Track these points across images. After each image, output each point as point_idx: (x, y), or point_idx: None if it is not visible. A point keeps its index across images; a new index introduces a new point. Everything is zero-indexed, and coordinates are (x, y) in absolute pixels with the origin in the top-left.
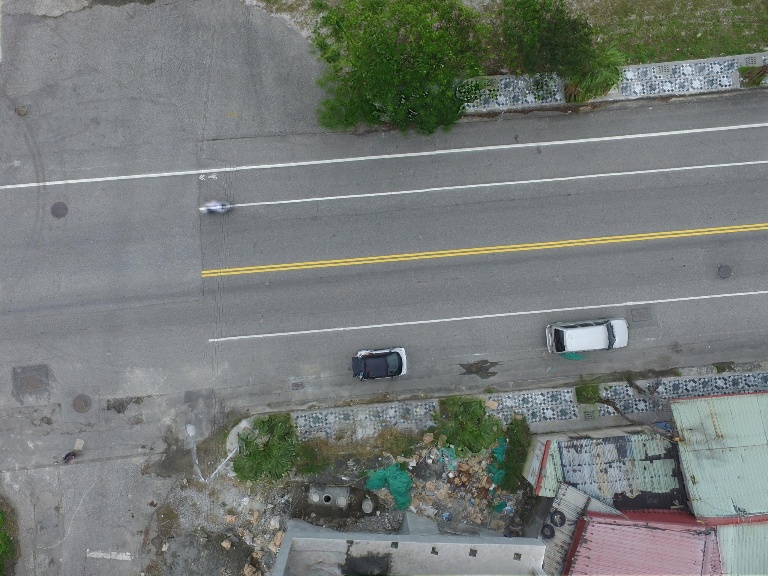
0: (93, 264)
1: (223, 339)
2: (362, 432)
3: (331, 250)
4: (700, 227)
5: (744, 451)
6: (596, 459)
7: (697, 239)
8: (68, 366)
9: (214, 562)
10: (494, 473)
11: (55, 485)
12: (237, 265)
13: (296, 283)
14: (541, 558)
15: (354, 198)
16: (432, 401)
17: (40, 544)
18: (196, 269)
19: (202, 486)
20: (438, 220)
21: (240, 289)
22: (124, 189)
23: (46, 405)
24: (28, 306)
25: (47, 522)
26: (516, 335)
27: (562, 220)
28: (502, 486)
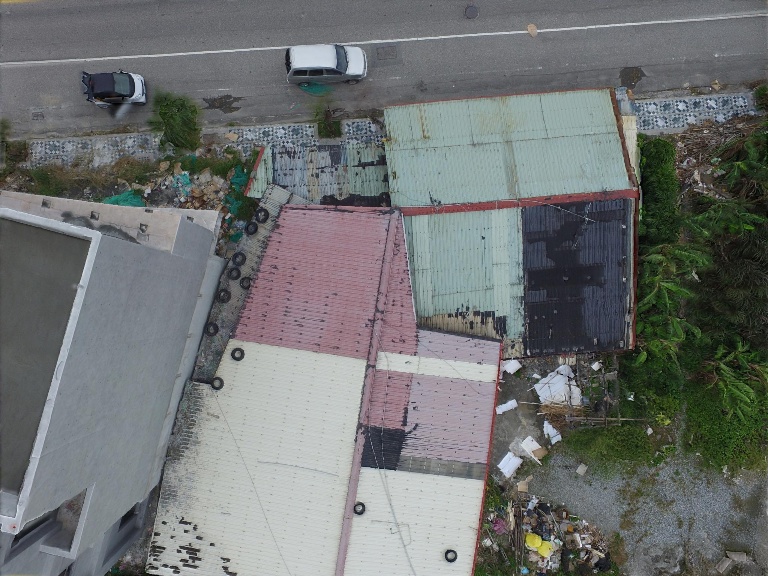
0: None
1: None
2: (99, 161)
3: None
4: None
5: (448, 151)
6: (309, 165)
7: None
8: None
9: None
10: (232, 204)
11: None
12: None
13: (38, 13)
14: (213, 222)
15: None
16: None
17: None
18: None
19: None
20: None
21: None
22: None
23: None
24: None
25: None
26: (260, 70)
27: None
28: (238, 216)
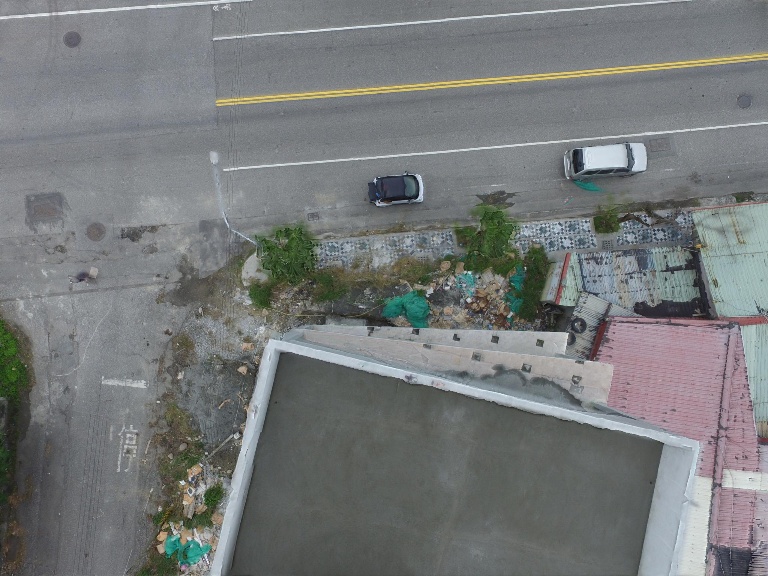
0: (106, 93)
1: (238, 169)
2: (378, 261)
3: (346, 80)
4: (719, 57)
5: (767, 256)
6: (616, 270)
7: (716, 69)
8: (82, 194)
9: (230, 385)
10: (512, 302)
11: (69, 313)
12: (251, 95)
13: (311, 113)
14: (564, 344)
15: (369, 29)
16: (449, 230)
17: (55, 371)
18: (210, 99)
19: (217, 315)
20: (454, 50)
21: (255, 119)
22: (137, 19)
23: (60, 233)
24: (41, 134)
25: (62, 349)
26: (533, 165)
27: (579, 50)
28: (520, 314)
